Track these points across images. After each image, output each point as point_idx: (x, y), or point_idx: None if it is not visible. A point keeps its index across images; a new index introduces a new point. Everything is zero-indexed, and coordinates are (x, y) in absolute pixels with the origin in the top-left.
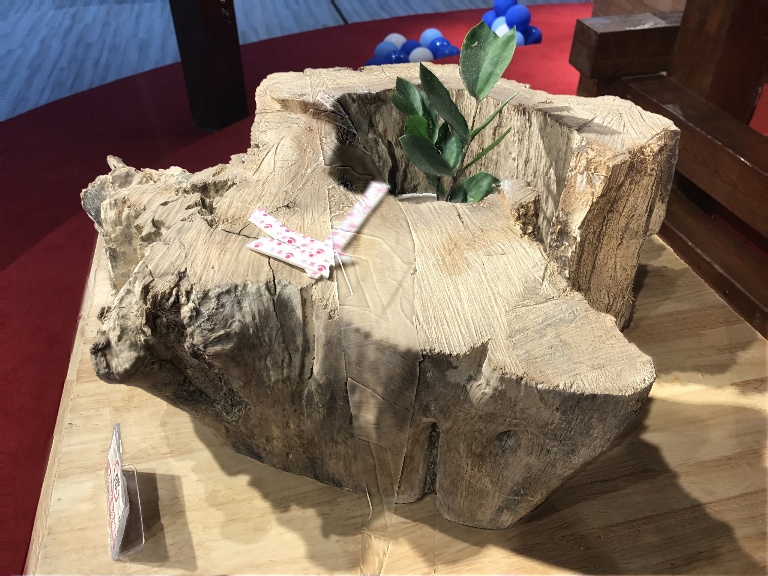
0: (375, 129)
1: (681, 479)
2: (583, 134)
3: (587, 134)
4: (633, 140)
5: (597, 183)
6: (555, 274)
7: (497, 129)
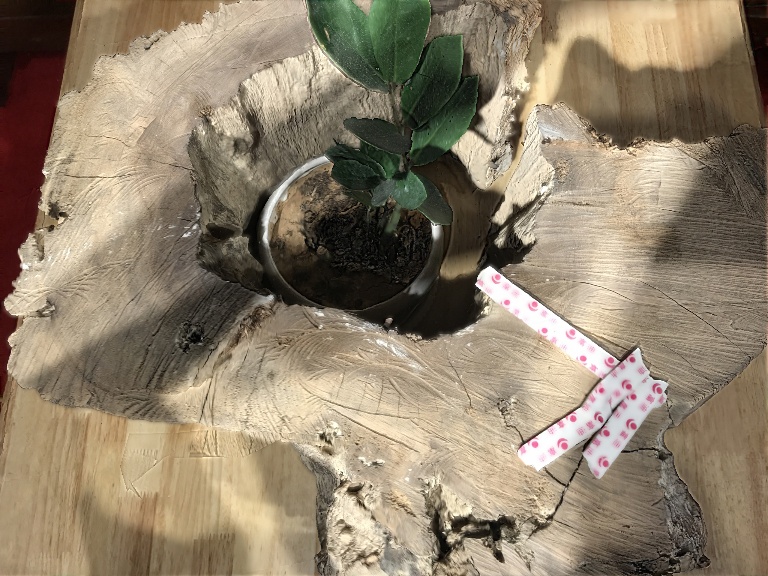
0: None
1: (635, 138)
2: (469, 0)
3: None
4: None
5: (530, 32)
6: (691, 148)
7: (313, 79)
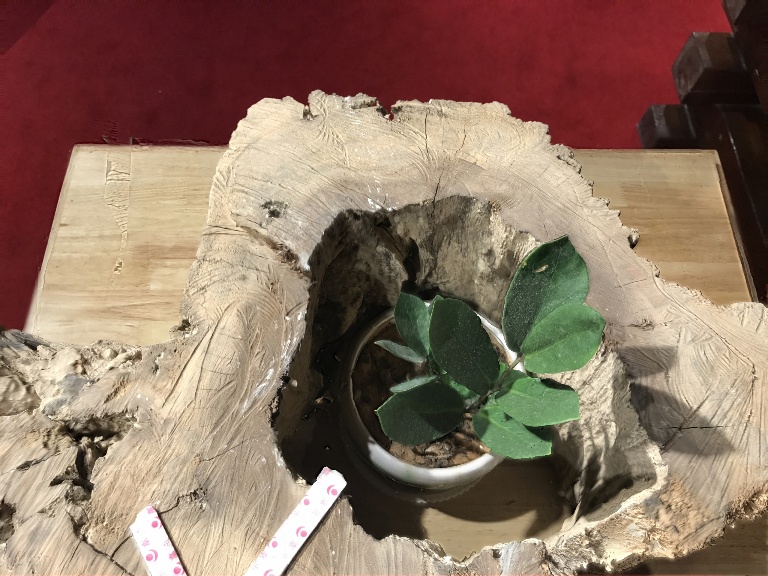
0: (392, 229)
1: None
2: (668, 456)
3: (675, 457)
4: (747, 475)
5: None
6: None
7: None
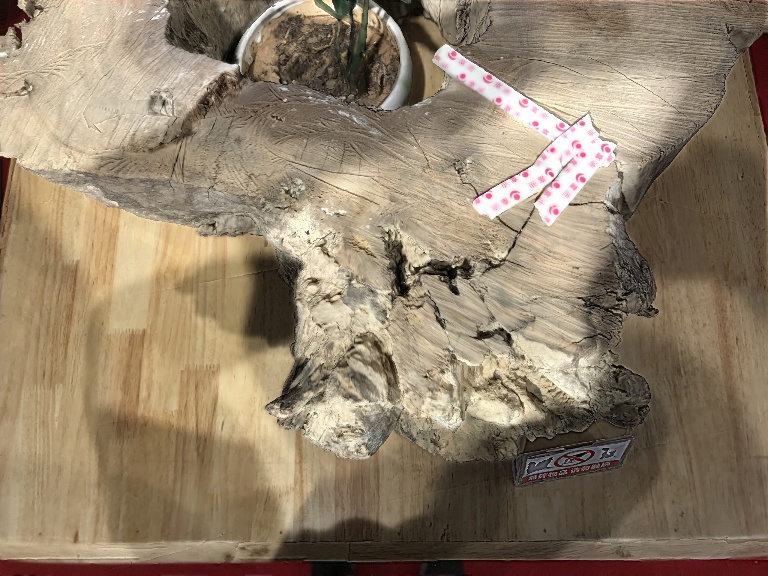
0: None
1: None
2: None
3: None
4: None
5: None
6: None
7: None
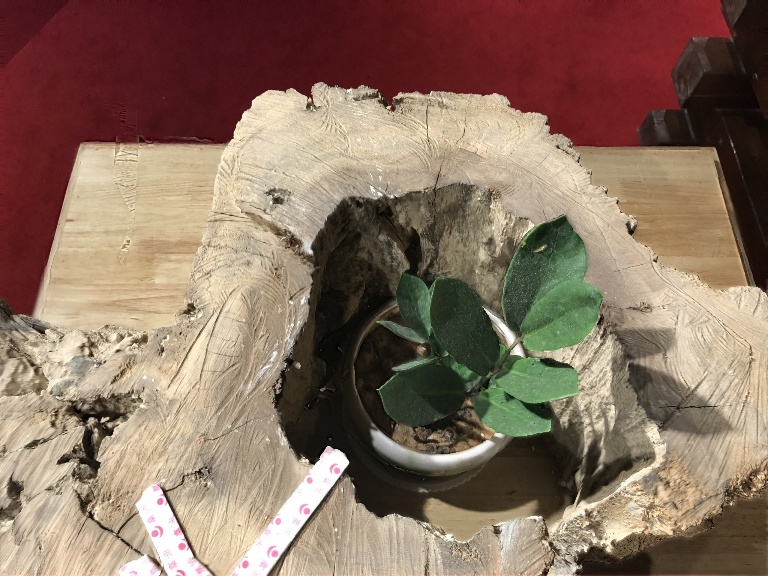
0: (394, 218)
1: None
2: (667, 435)
3: (673, 435)
4: (744, 453)
5: None
6: None
7: None
